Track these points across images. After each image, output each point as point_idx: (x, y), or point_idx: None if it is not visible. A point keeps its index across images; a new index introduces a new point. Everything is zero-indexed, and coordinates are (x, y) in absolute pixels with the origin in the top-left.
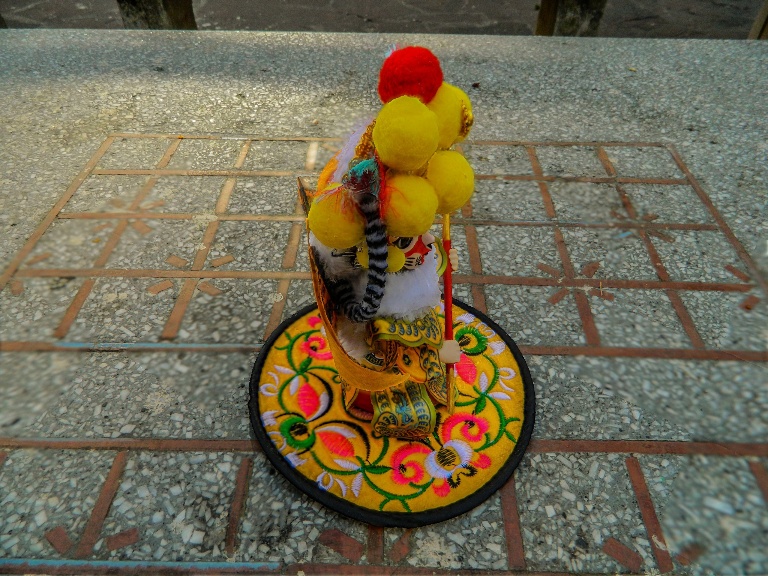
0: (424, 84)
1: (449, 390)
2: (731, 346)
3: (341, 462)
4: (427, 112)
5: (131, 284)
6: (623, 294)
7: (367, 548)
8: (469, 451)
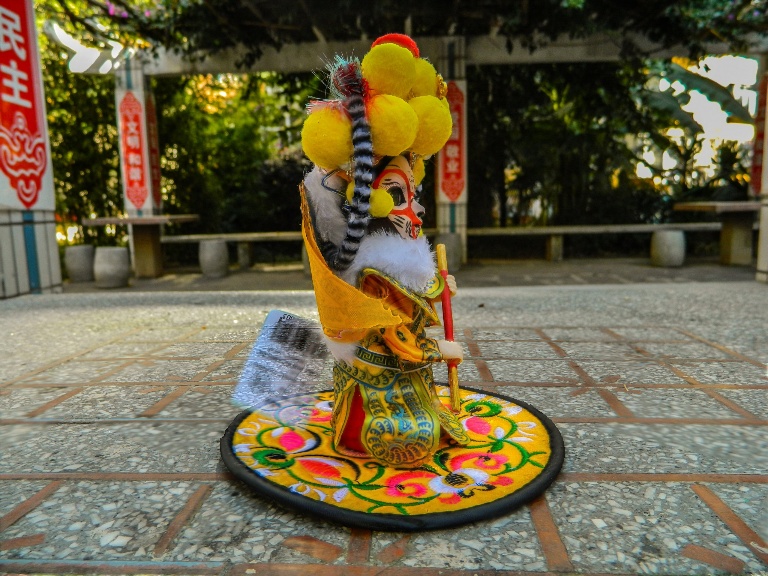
0: (402, 43)
1: (452, 387)
2: None
3: (323, 479)
4: None
5: (123, 389)
6: (652, 391)
7: (347, 551)
8: (485, 474)
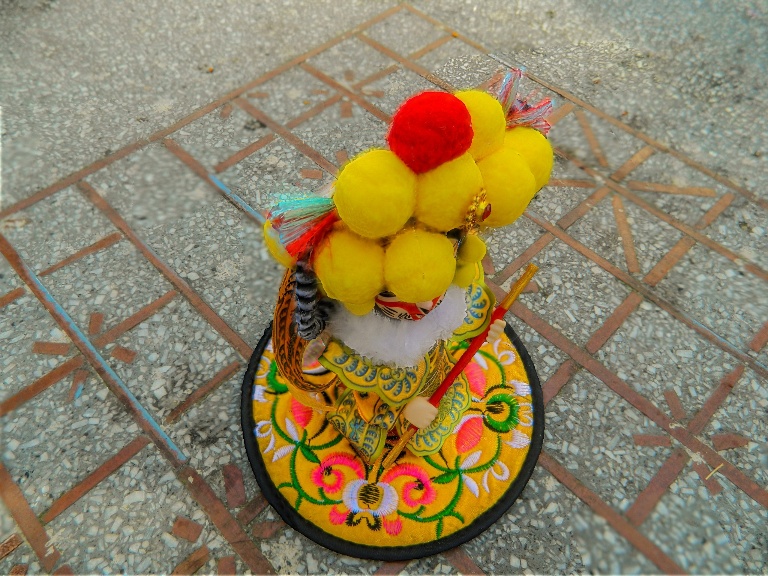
0: (417, 151)
1: (397, 445)
2: None
3: (289, 424)
4: (391, 187)
5: (295, 157)
6: (736, 498)
7: (246, 505)
8: (392, 507)
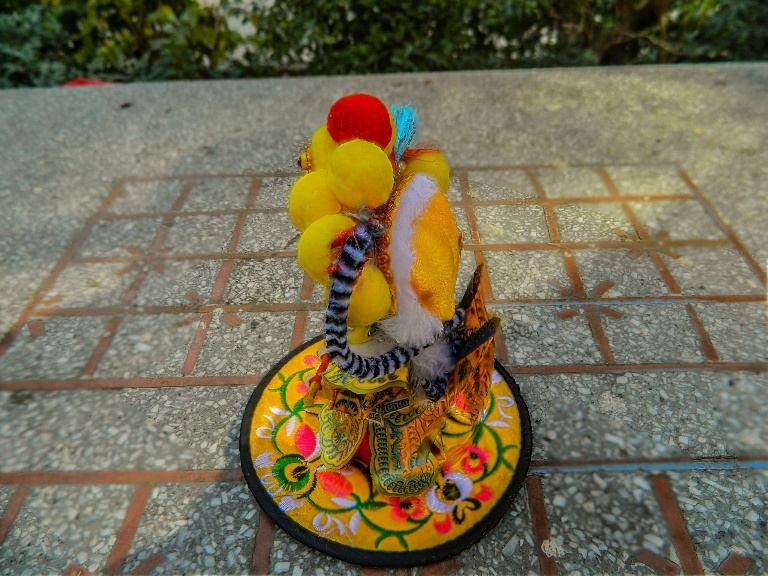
0: None
1: None
2: None
3: None
4: None
5: None
6: None
7: None
8: None
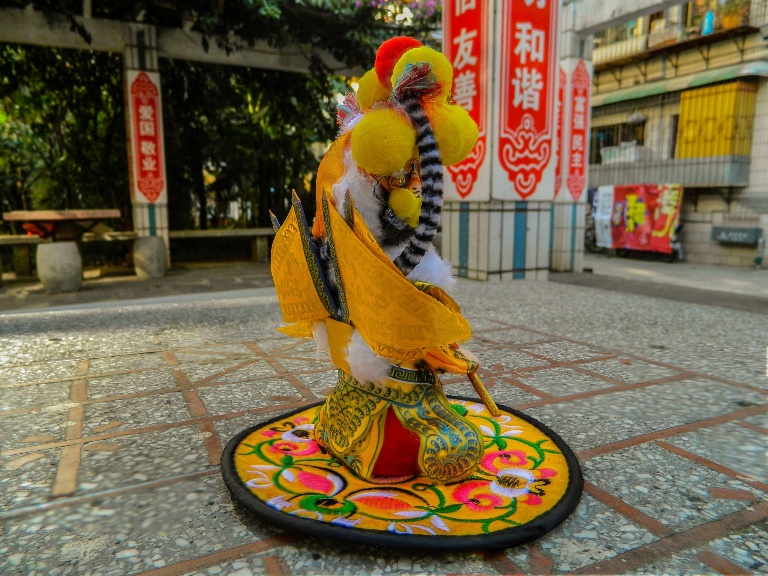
0: None
1: (485, 393)
2: (642, 380)
3: (403, 513)
4: None
5: None
6: (537, 373)
7: None
8: (526, 470)
